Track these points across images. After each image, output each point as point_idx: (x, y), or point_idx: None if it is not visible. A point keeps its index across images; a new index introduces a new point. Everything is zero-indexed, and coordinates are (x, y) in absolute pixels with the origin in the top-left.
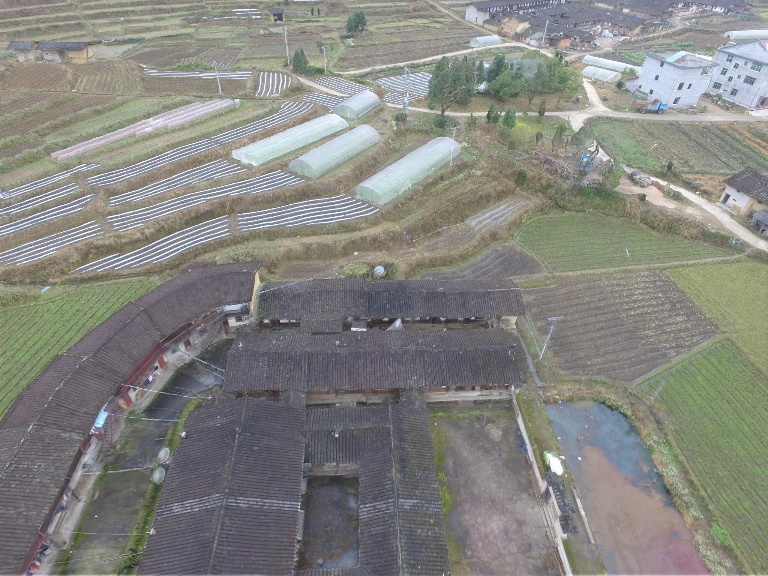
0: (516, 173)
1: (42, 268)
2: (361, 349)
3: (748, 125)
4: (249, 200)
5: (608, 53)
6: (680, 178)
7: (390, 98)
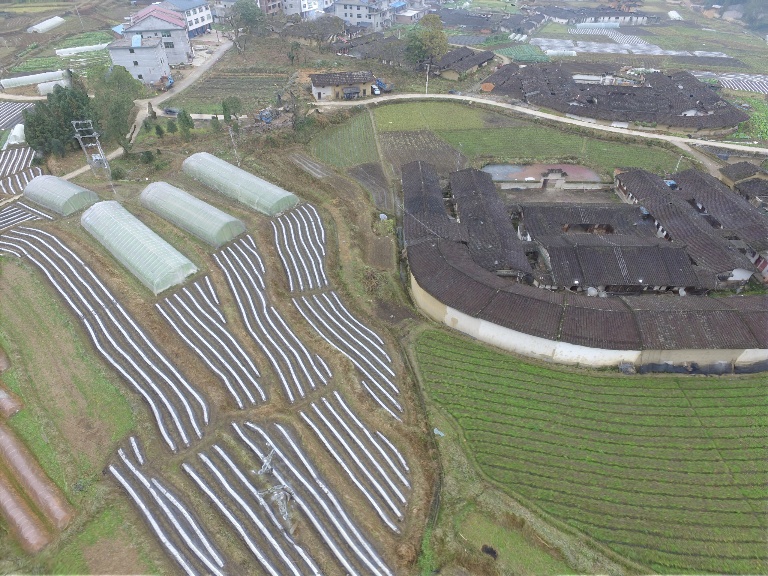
0: (269, 141)
1: (413, 435)
2: (487, 212)
3: (217, 70)
4: (277, 274)
5: (2, 73)
6: (286, 101)
7: (6, 190)
